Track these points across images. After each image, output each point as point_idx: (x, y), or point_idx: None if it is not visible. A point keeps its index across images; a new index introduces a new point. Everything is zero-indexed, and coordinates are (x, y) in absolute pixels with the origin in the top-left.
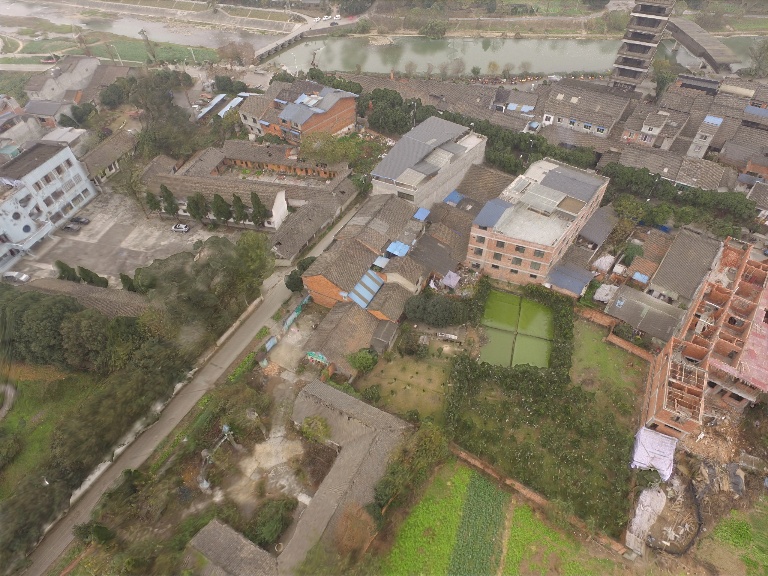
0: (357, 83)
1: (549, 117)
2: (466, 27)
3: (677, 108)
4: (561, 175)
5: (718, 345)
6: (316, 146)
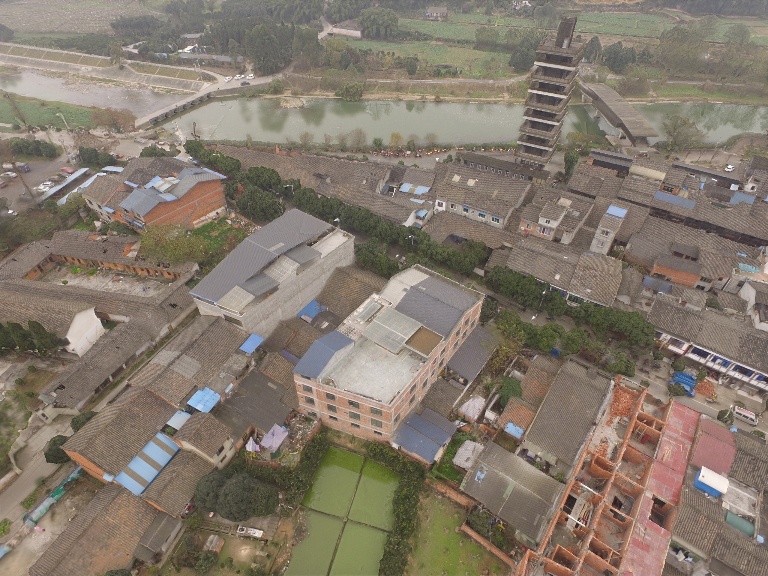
0: (235, 159)
1: (441, 203)
2: (385, 89)
3: (585, 191)
4: (423, 293)
5: (589, 558)
6: (156, 243)
